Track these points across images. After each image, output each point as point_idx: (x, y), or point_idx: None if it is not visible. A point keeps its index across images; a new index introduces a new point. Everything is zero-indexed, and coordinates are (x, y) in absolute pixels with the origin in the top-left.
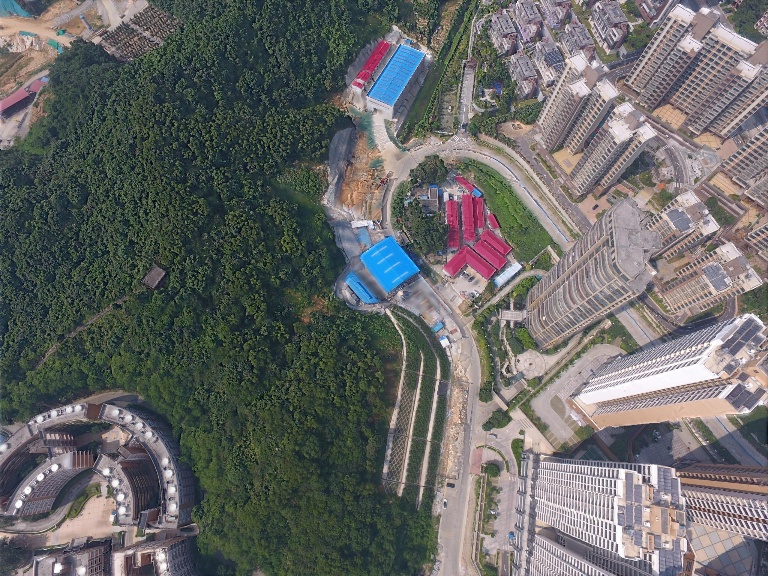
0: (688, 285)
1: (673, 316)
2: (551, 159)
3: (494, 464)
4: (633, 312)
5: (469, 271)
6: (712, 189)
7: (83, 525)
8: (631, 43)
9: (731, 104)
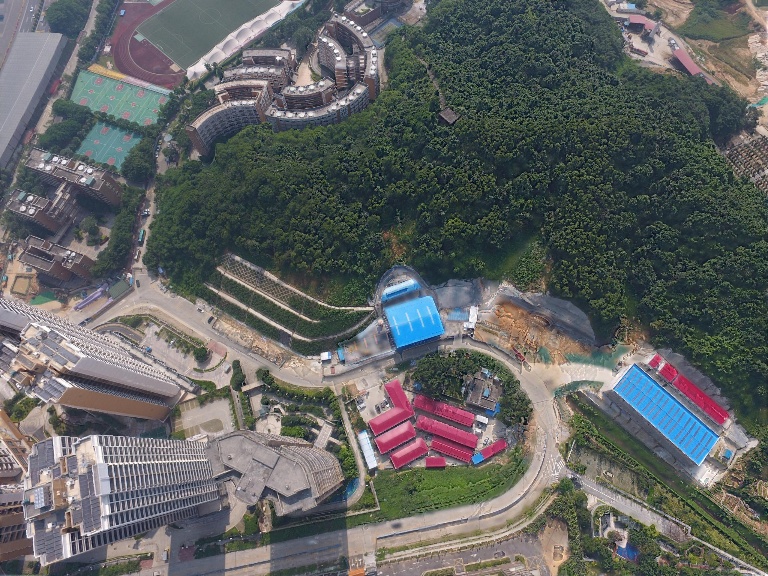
0: None
1: None
2: (492, 571)
3: (204, 356)
4: (265, 570)
5: None
6: None
7: (304, 81)
8: None
9: None
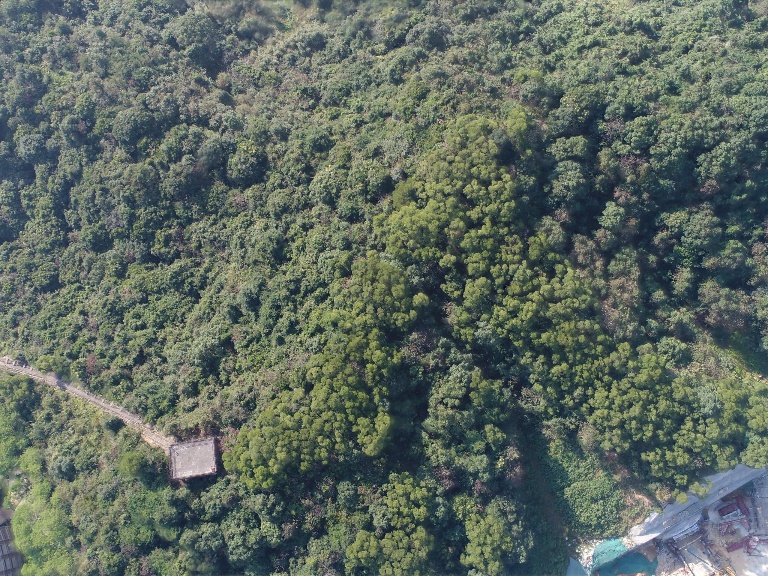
0: None
1: None
2: None
3: None
4: None
5: None
6: None
7: None
8: None
9: None
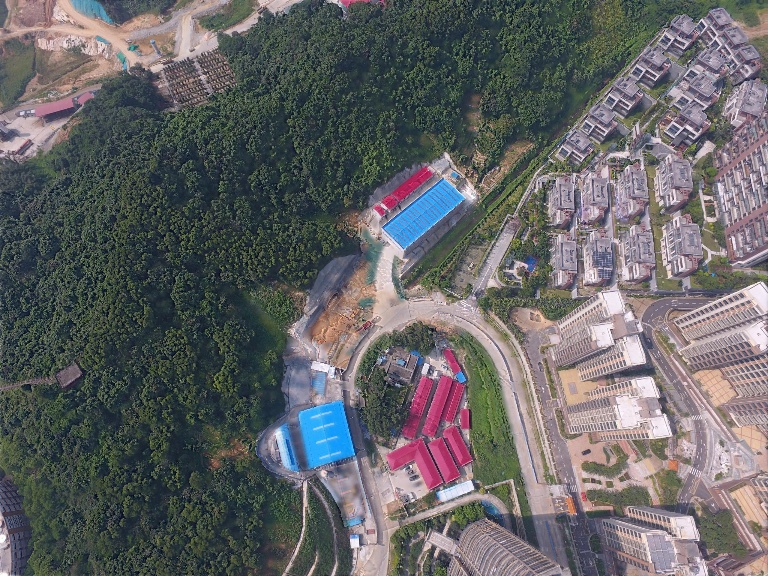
0: None
1: None
2: (556, 375)
3: None
4: None
5: (415, 467)
6: (731, 502)
7: None
8: (699, 280)
9: None
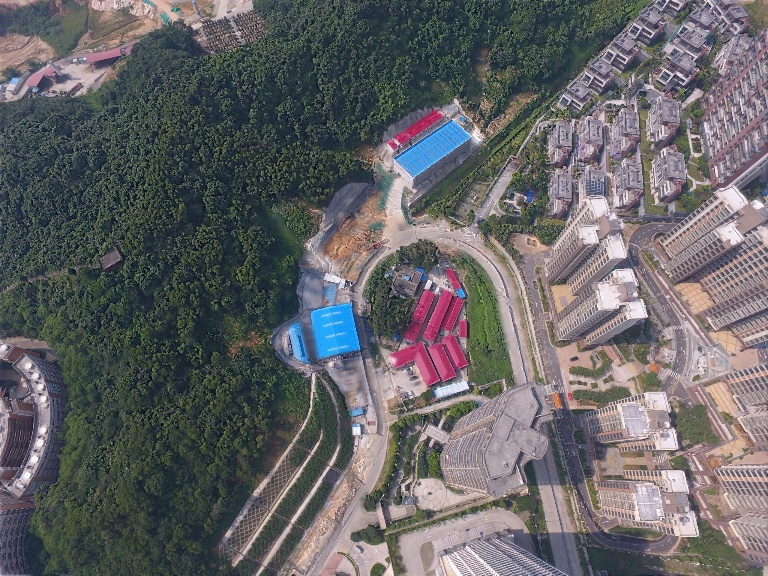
0: (620, 494)
1: (601, 516)
2: (548, 290)
3: None
4: (559, 490)
5: (415, 369)
6: (706, 396)
7: None
8: (683, 203)
9: (759, 314)
